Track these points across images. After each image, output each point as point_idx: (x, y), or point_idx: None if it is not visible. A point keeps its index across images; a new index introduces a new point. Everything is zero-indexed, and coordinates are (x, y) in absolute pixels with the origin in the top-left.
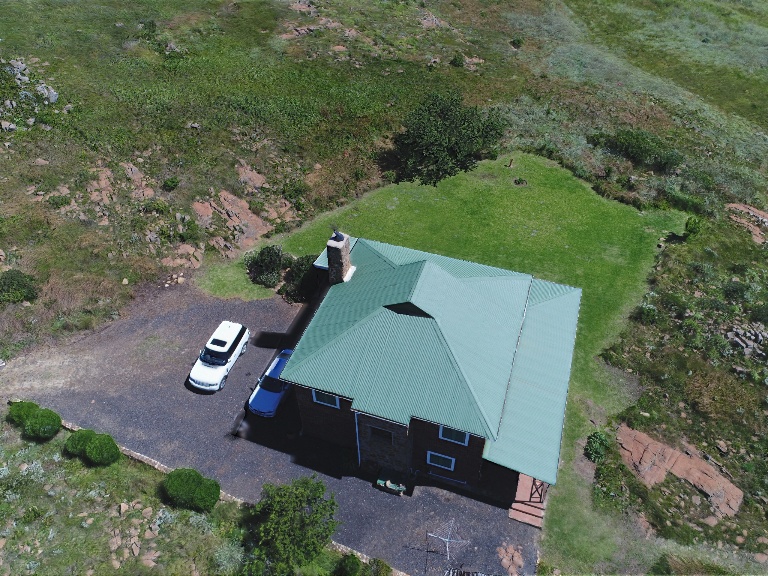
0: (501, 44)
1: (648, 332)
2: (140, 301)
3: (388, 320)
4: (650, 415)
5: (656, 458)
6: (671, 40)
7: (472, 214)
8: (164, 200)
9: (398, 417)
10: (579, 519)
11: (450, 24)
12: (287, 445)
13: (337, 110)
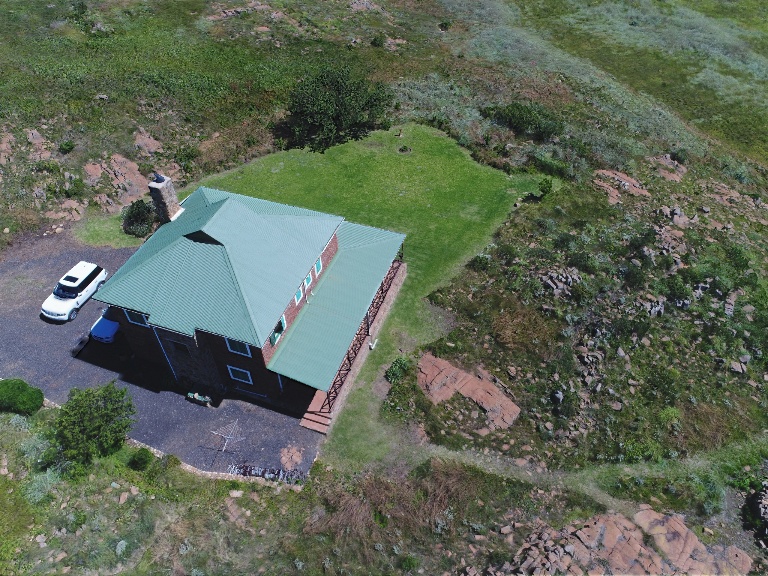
0: (428, 26)
1: (478, 278)
2: (17, 247)
3: (186, 247)
4: (454, 345)
5: (448, 380)
6: (600, 23)
7: (349, 177)
8: (58, 161)
9: (184, 329)
10: (363, 428)
11: (383, 8)
12: (118, 365)
13: (247, 85)
